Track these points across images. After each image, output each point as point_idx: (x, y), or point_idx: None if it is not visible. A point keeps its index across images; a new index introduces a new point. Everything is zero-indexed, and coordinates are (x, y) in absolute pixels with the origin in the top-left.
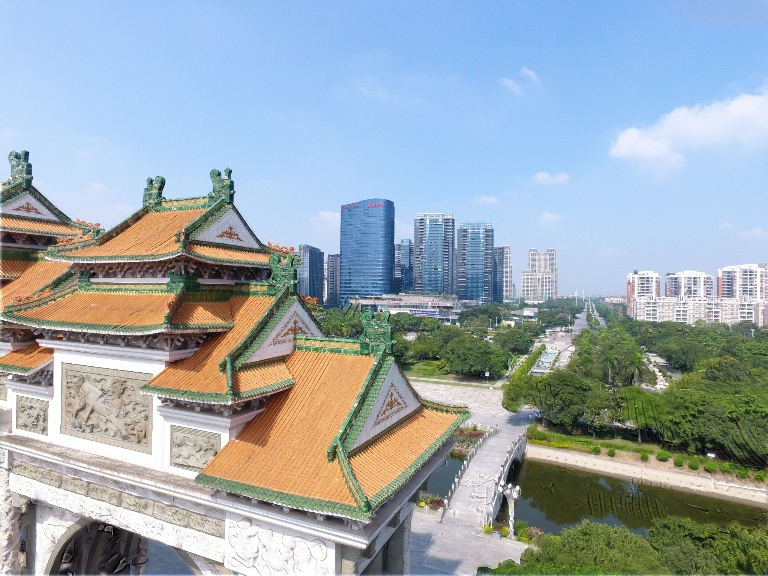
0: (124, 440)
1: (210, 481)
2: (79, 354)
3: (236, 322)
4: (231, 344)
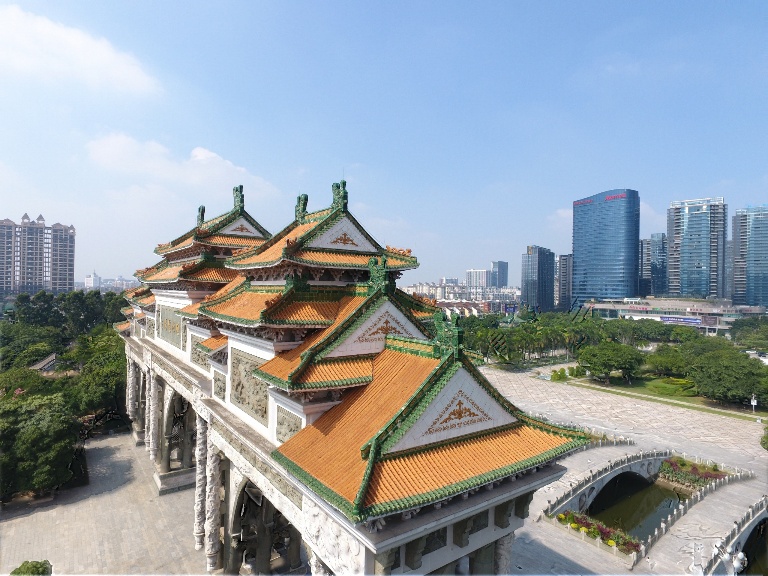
0: (256, 413)
1: (278, 457)
2: (238, 341)
3: (336, 320)
4: None
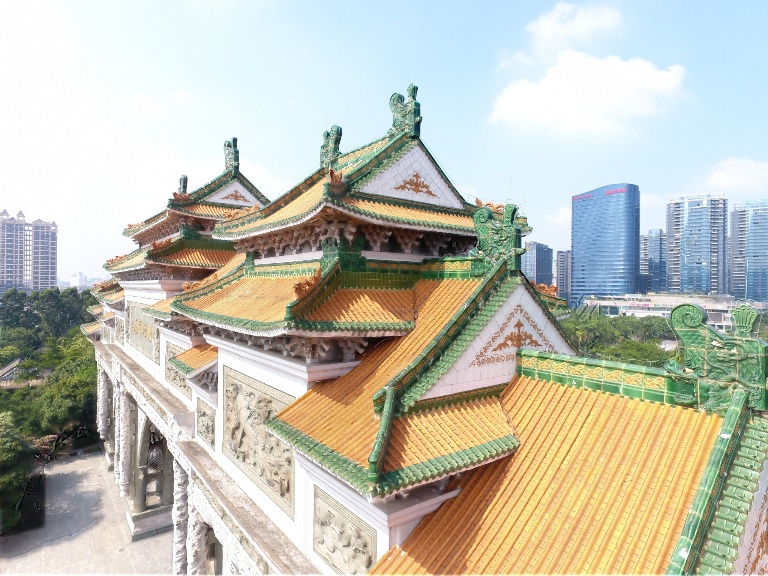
0: (269, 486)
1: None
2: (235, 356)
3: (418, 321)
4: (405, 359)
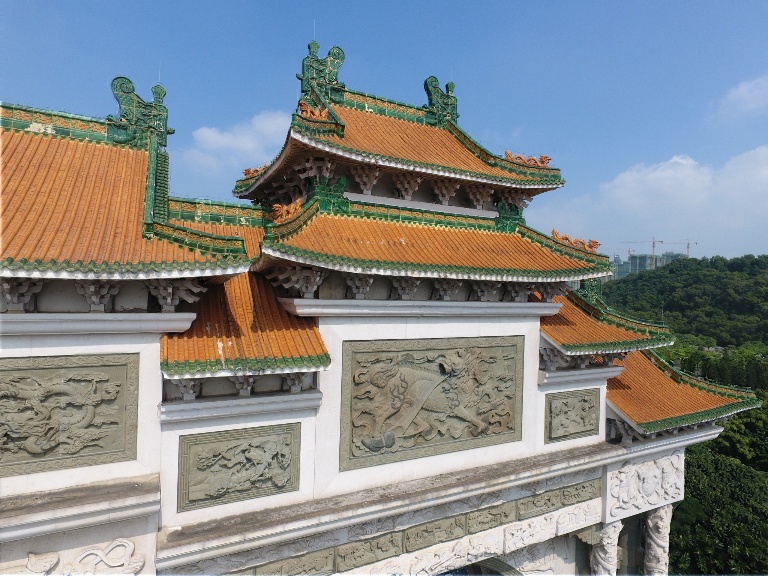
0: (477, 436)
1: (656, 425)
2: (389, 321)
3: None
4: None
